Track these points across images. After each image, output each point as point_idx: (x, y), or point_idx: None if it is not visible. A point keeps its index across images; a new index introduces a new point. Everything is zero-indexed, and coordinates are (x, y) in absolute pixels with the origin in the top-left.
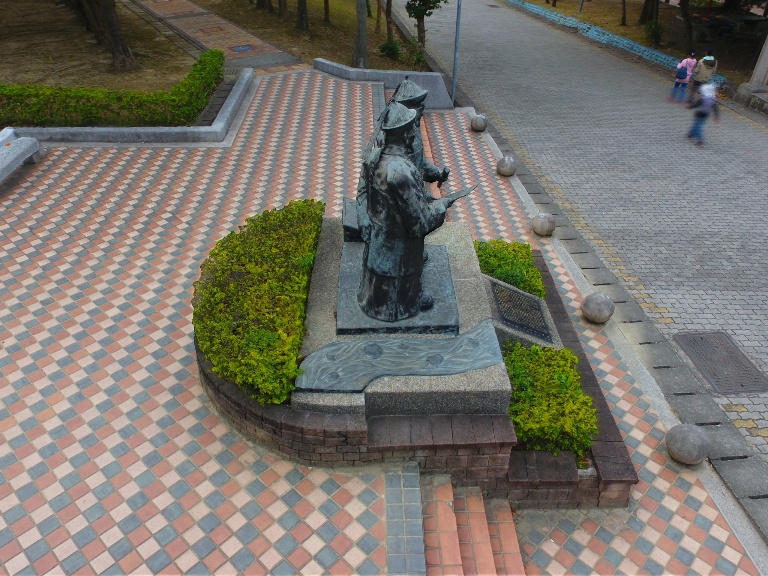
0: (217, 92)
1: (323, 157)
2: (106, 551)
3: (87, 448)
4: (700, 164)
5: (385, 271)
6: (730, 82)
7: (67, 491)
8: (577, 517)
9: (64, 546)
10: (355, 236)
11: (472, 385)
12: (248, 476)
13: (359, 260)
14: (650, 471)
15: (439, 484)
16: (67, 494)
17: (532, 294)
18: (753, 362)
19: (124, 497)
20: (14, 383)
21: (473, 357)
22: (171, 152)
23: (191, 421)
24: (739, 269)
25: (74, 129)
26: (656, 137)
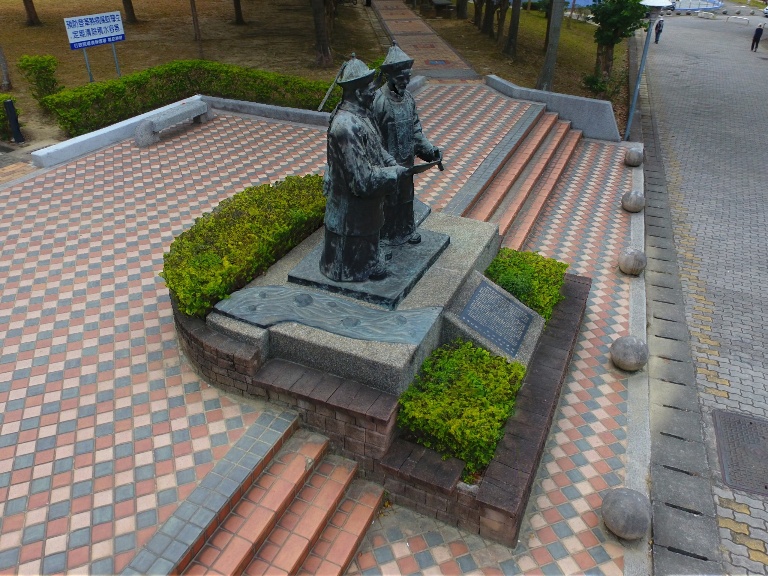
0: None
1: None
2: (26, 388)
3: (73, 318)
4: None
5: (332, 227)
6: None
7: (37, 341)
8: (451, 535)
9: (5, 374)
10: None
11: (366, 352)
12: (159, 374)
13: None
14: (570, 527)
15: (312, 441)
16: (35, 343)
17: (532, 309)
18: None
19: (67, 358)
20: (66, 263)
21: (389, 331)
22: (306, 131)
23: (154, 323)
24: None
25: (243, 102)
26: None
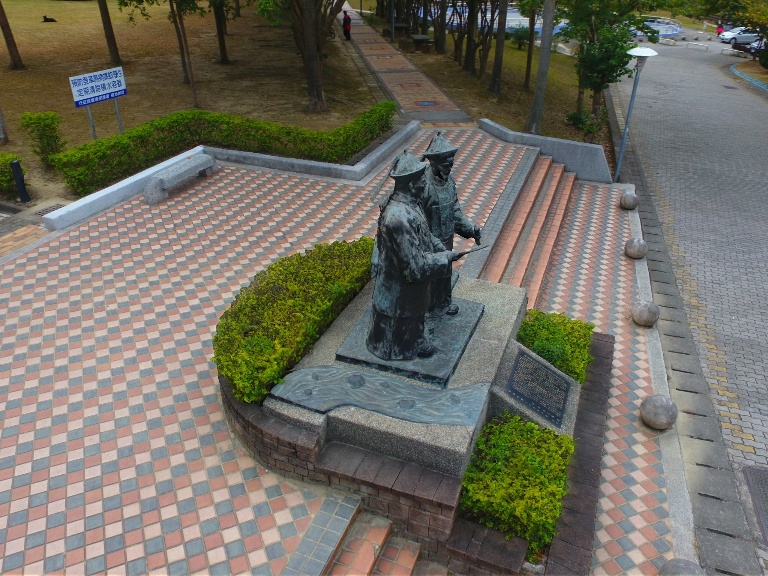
0: (380, 138)
1: None
2: (83, 481)
3: (116, 400)
4: None
5: (383, 309)
6: None
7: (84, 428)
8: None
9: (59, 467)
10: None
11: (428, 437)
12: (215, 460)
13: None
14: None
15: (376, 525)
16: (83, 430)
17: (567, 375)
18: None
19: (118, 445)
20: (98, 338)
21: (445, 412)
22: (313, 183)
23: (199, 403)
24: None
25: (246, 153)
26: None
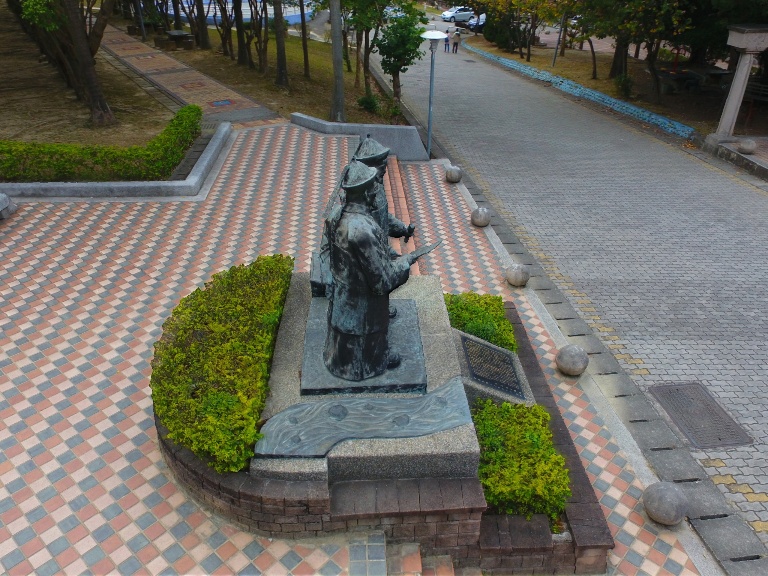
0: (194, 146)
1: (297, 210)
2: None
3: (34, 522)
4: (671, 213)
5: (349, 329)
6: (698, 133)
7: (8, 571)
8: None
9: None
10: (323, 292)
11: (439, 447)
12: (204, 550)
13: (326, 316)
14: (628, 533)
15: (407, 554)
16: (8, 575)
17: (504, 348)
18: (729, 414)
19: None
20: None
21: (441, 417)
22: (144, 206)
23: (147, 490)
24: (712, 318)
25: (46, 184)
26: (628, 186)
